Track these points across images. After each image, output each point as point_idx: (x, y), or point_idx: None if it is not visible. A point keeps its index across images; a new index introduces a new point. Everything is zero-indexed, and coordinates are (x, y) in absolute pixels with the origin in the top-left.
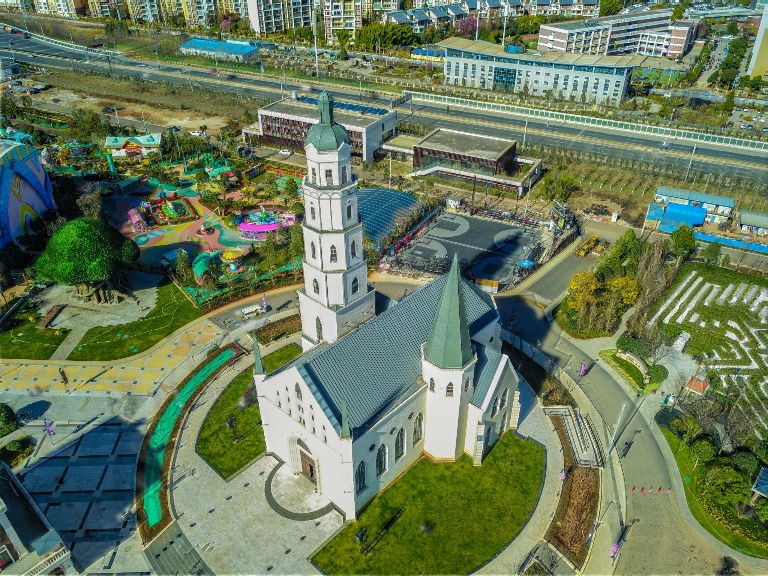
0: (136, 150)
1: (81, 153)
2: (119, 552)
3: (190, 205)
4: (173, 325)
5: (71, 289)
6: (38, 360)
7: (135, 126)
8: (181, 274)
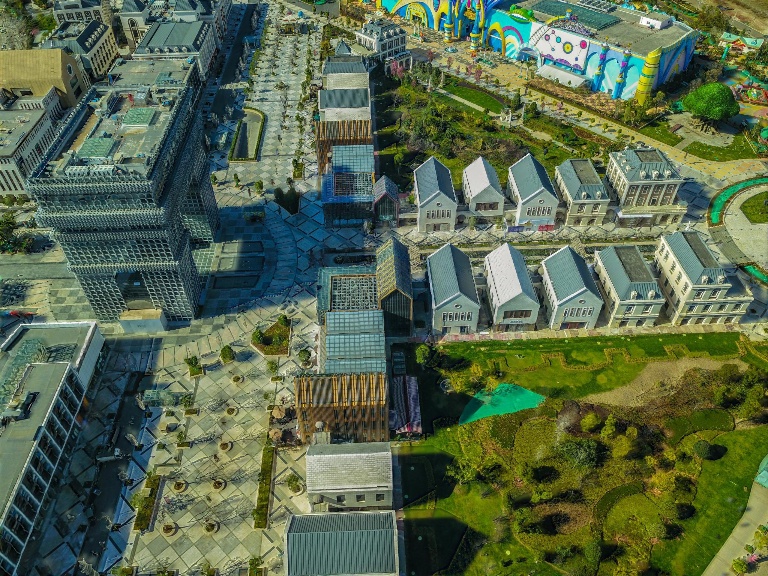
0: (740, 47)
1: (699, 38)
2: (697, 225)
3: (766, 96)
4: (740, 156)
5: (688, 119)
6: (668, 145)
7: (739, 27)
8: (753, 133)
